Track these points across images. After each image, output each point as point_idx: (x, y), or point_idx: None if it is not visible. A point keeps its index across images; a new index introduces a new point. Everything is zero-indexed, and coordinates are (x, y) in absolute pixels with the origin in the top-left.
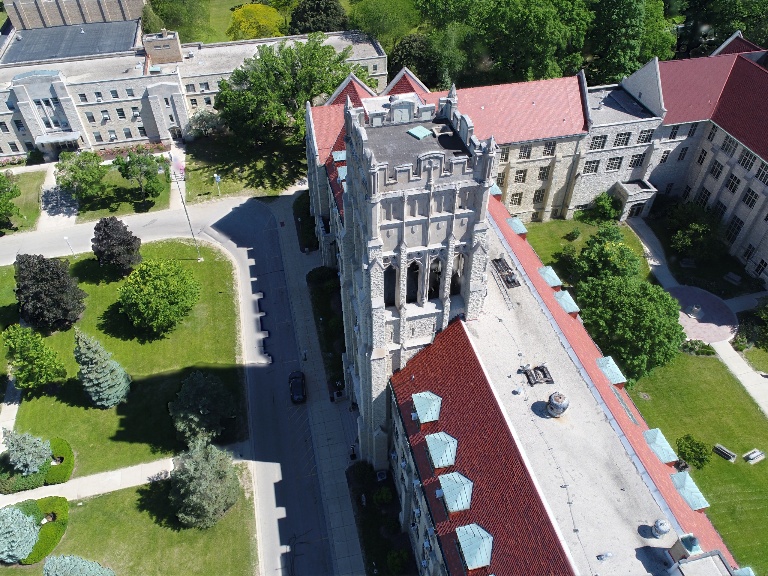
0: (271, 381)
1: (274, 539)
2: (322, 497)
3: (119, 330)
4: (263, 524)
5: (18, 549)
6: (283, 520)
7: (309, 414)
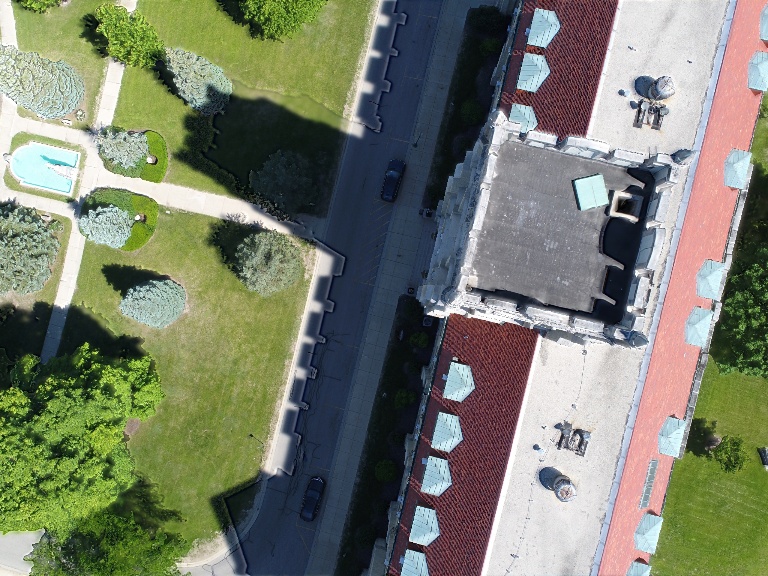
0: (370, 157)
1: (316, 327)
2: (369, 310)
3: (233, 3)
4: (311, 309)
5: (113, 243)
6: (329, 314)
7: (392, 217)
